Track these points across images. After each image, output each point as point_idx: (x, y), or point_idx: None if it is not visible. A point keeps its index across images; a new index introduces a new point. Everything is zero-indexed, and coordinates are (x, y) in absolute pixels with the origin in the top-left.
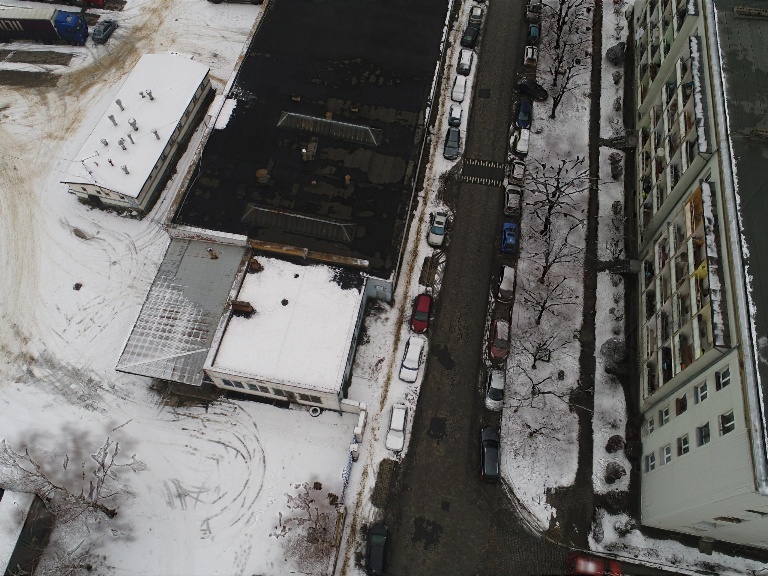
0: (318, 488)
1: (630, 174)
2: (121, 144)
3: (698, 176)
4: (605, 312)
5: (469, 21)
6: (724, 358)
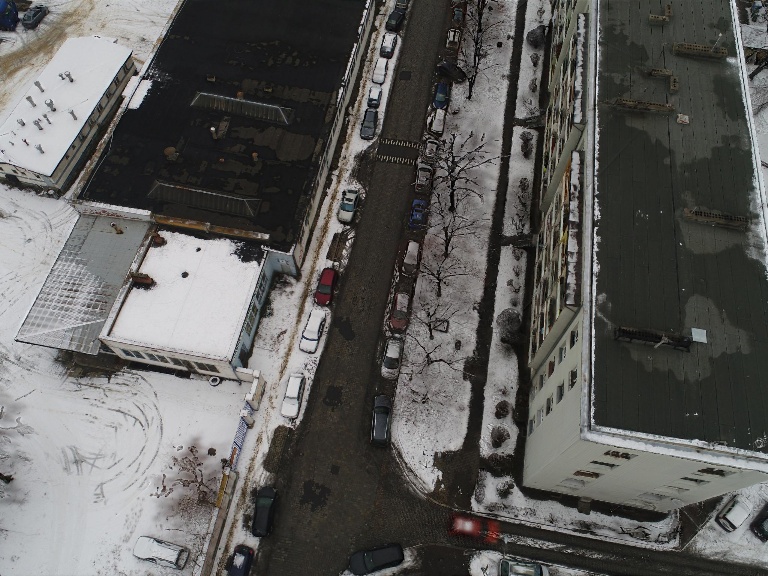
0: (212, 454)
1: (541, 152)
2: (36, 124)
3: (577, 147)
4: (506, 285)
5: (395, 6)
6: (576, 317)
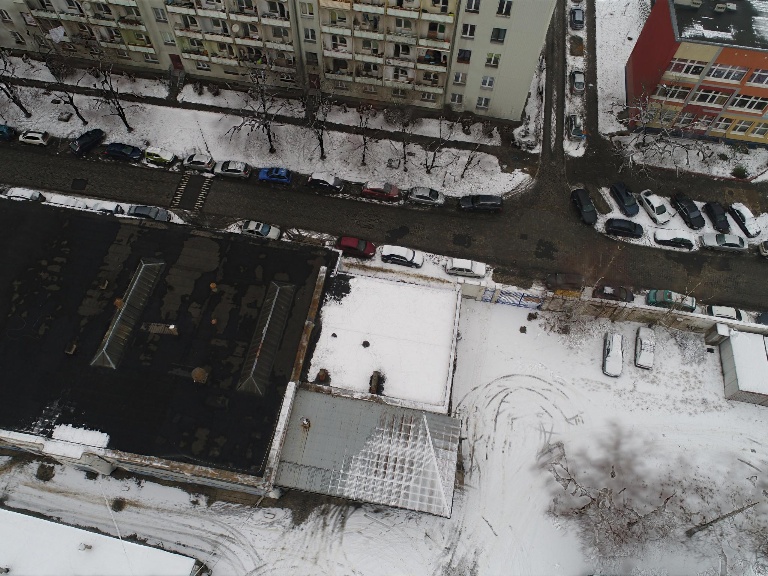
0: (525, 329)
1: (214, 84)
2: None
3: None
4: (354, 120)
5: None
6: None
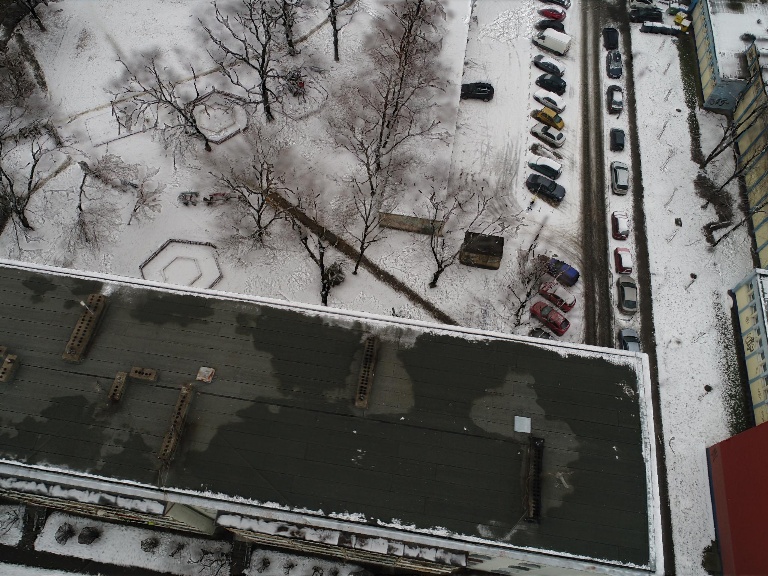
0: None
1: None
2: None
3: None
4: None
5: None
6: None
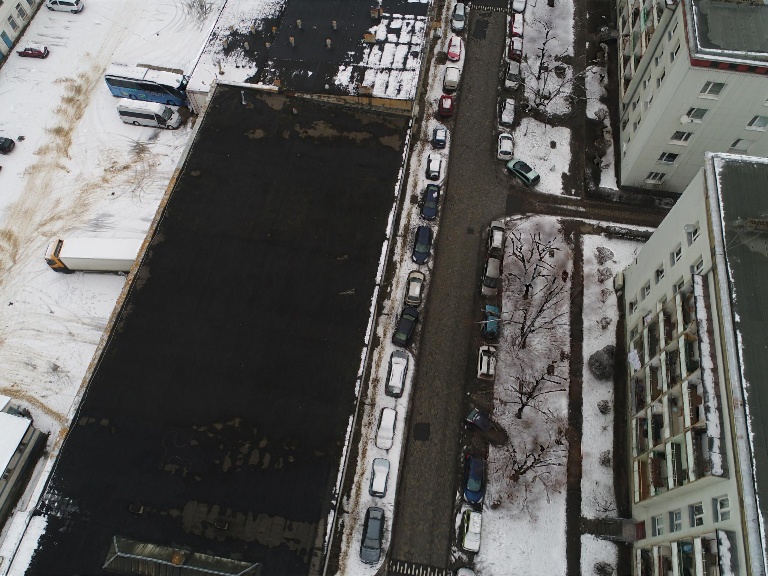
0: None
1: None
2: None
3: None
4: None
5: (405, 301)
6: None
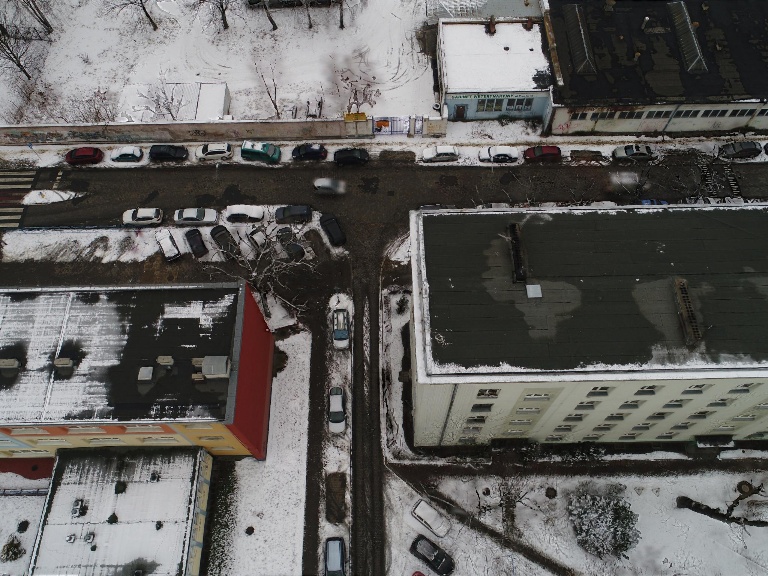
0: None
1: None
2: None
3: None
4: None
5: None
6: None
